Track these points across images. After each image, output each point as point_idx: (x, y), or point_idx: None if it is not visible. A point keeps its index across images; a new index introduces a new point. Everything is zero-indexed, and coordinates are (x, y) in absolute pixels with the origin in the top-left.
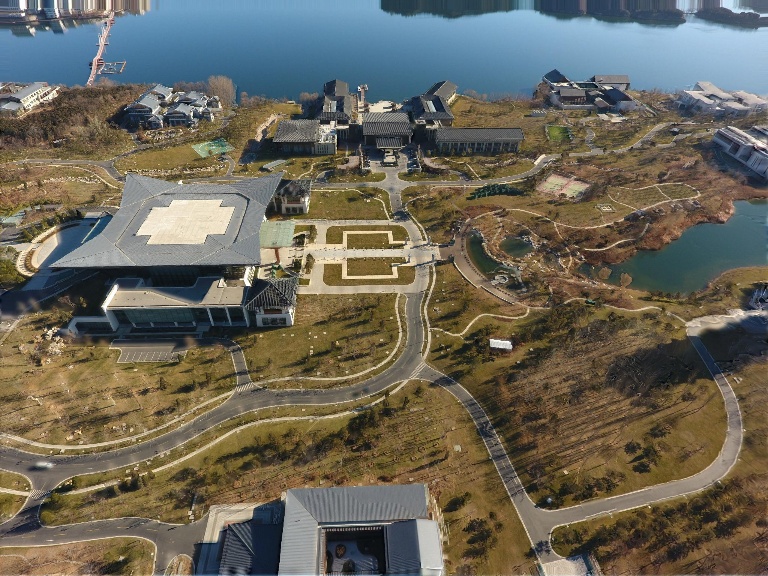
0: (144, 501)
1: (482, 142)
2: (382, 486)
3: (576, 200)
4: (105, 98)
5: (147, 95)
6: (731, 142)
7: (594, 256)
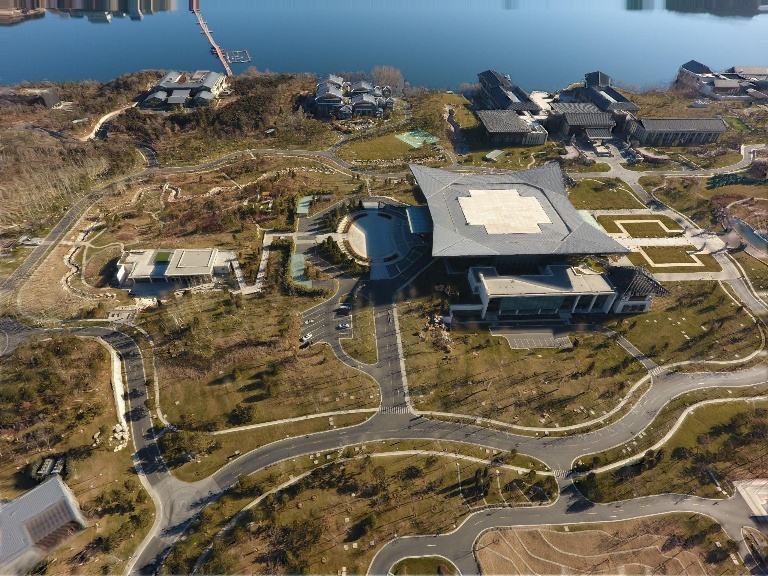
0: (669, 478)
1: (686, 133)
2: None
3: None
4: None
5: (327, 85)
6: None
7: None
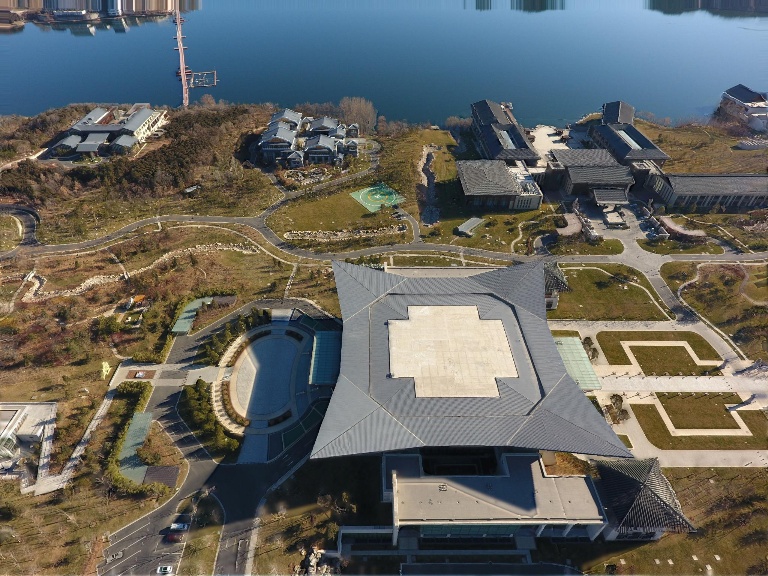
0: None
1: (730, 195)
2: None
3: None
4: (225, 126)
5: (278, 124)
6: None
7: None
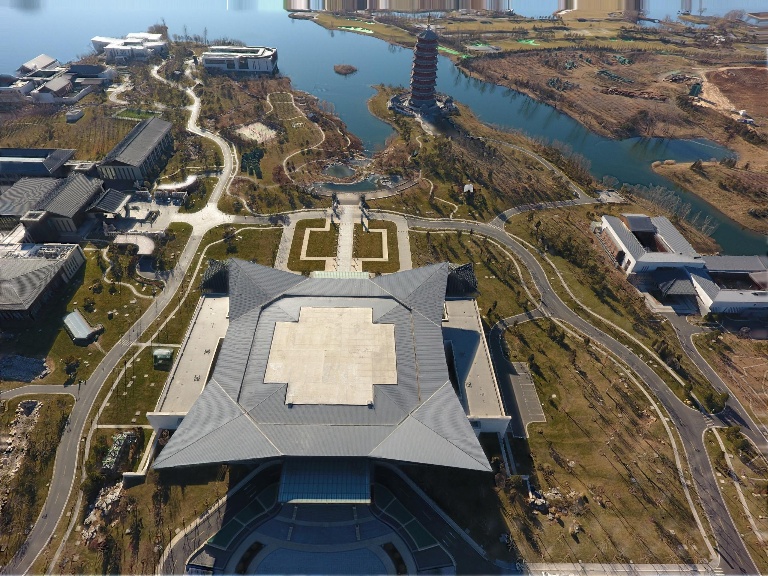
0: None
1: (156, 145)
2: (613, 228)
3: None
4: None
5: None
6: (224, 61)
7: (356, 146)
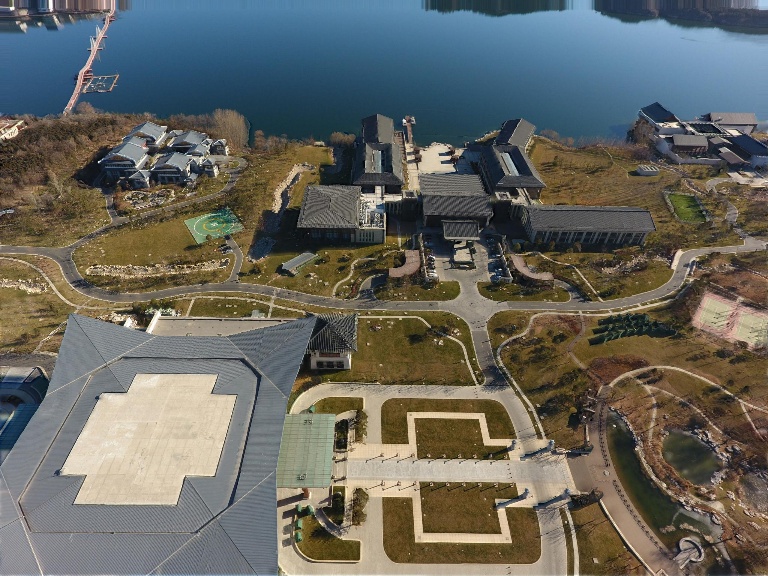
0: None
1: (594, 231)
2: None
3: (762, 352)
4: (78, 140)
5: (131, 139)
6: None
7: None
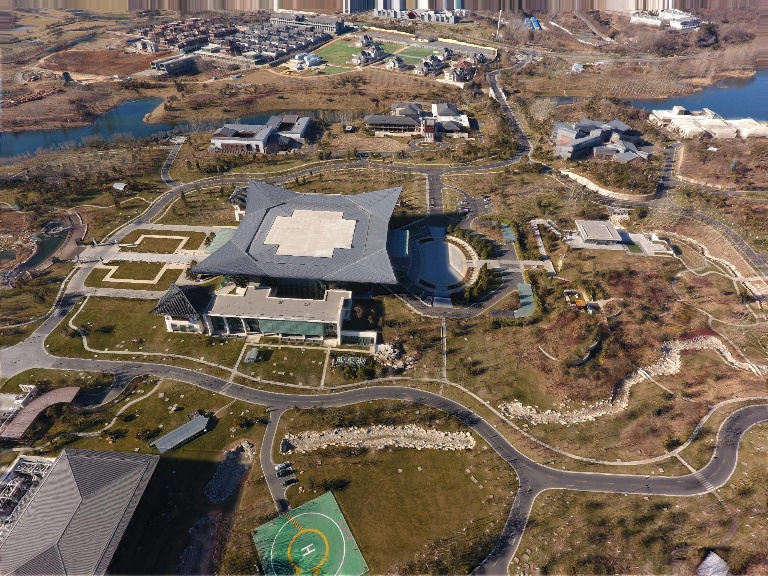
0: None
1: None
2: (227, 139)
3: None
4: None
5: None
6: None
7: None
